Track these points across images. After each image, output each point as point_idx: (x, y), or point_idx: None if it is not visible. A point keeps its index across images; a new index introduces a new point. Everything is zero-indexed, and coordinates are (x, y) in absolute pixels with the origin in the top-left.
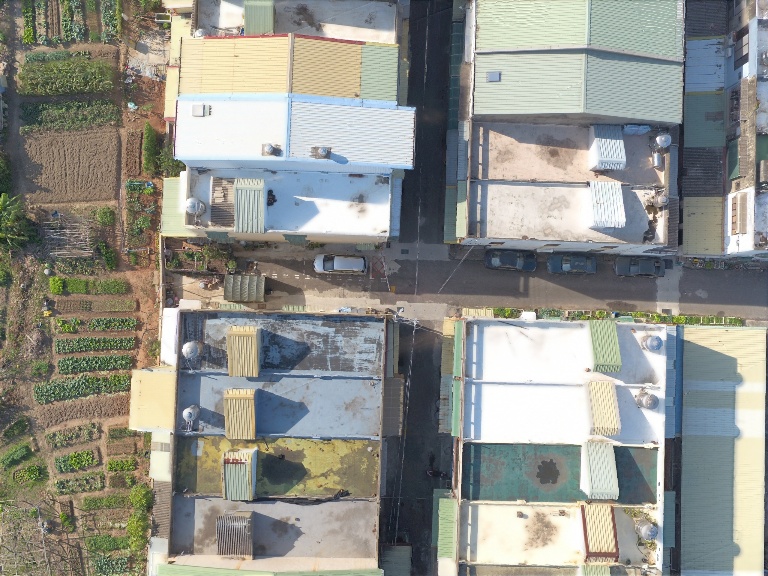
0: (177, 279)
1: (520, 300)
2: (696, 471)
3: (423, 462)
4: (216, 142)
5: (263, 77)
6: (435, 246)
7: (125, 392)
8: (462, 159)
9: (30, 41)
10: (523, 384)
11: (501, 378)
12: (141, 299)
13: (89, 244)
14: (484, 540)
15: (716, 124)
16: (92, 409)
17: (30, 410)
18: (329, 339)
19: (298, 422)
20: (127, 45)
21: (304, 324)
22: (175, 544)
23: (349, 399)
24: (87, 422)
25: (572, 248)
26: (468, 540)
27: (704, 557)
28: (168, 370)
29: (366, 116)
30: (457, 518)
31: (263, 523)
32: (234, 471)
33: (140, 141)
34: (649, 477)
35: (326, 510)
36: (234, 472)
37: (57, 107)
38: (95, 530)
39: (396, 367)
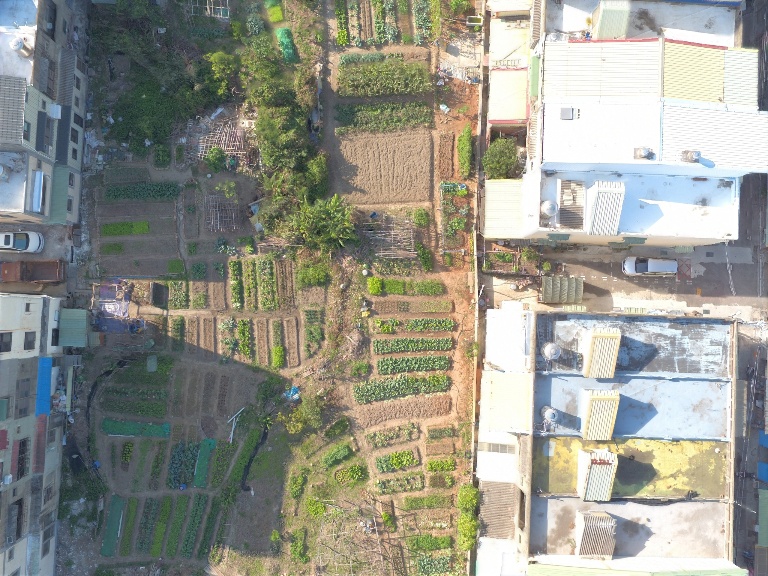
0: (488, 280)
1: None
2: None
3: None
4: (589, 145)
5: (630, 81)
6: (739, 249)
7: (443, 392)
8: None
9: (344, 43)
10: None
11: None
12: (456, 300)
13: None
14: None
15: None
16: (411, 409)
17: (349, 410)
18: (676, 341)
19: (647, 423)
20: (440, 47)
21: (652, 326)
22: None
23: (696, 401)
24: (406, 422)
25: None
26: None
27: None
28: (520, 371)
29: (730, 120)
30: None
31: None
32: (599, 472)
33: (452, 143)
34: None
35: (675, 511)
36: (599, 473)
37: (372, 109)
38: (416, 530)
39: None
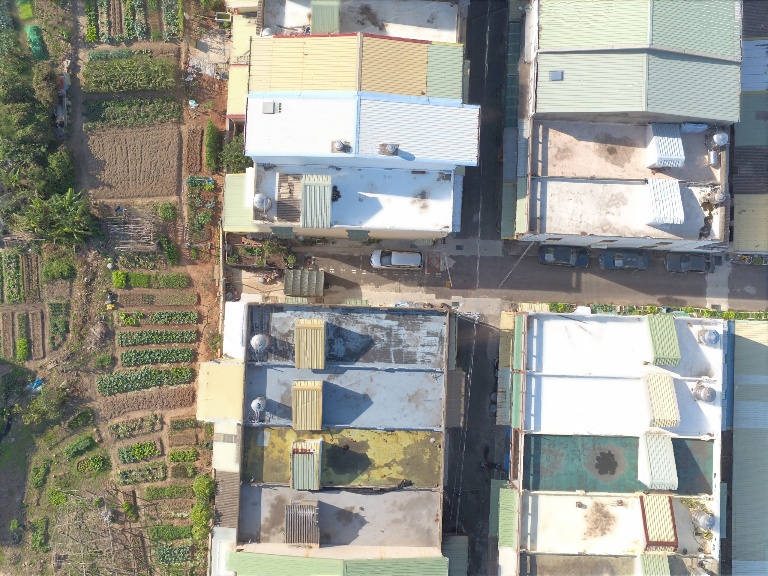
0: (236, 274)
1: (572, 295)
2: (747, 463)
3: (477, 454)
4: (287, 139)
5: (332, 75)
6: (489, 242)
7: (186, 384)
8: (522, 156)
9: (93, 39)
10: (582, 377)
11: (560, 371)
12: (202, 293)
13: (152, 239)
14: (544, 530)
15: (767, 123)
16: (154, 401)
17: (93, 402)
18: (392, 332)
19: (362, 413)
20: (188, 44)
21: (368, 317)
22: (242, 532)
23: (412, 391)
24: (149, 414)
25: (626, 244)
26: (528, 529)
27: (755, 548)
28: (235, 362)
29: (432, 114)
30: (518, 508)
31: (328, 512)
32: (302, 461)
33: (201, 138)
34: (705, 468)
35: (389, 500)
36: (302, 462)
37: (119, 104)
38: (157, 519)
39: None
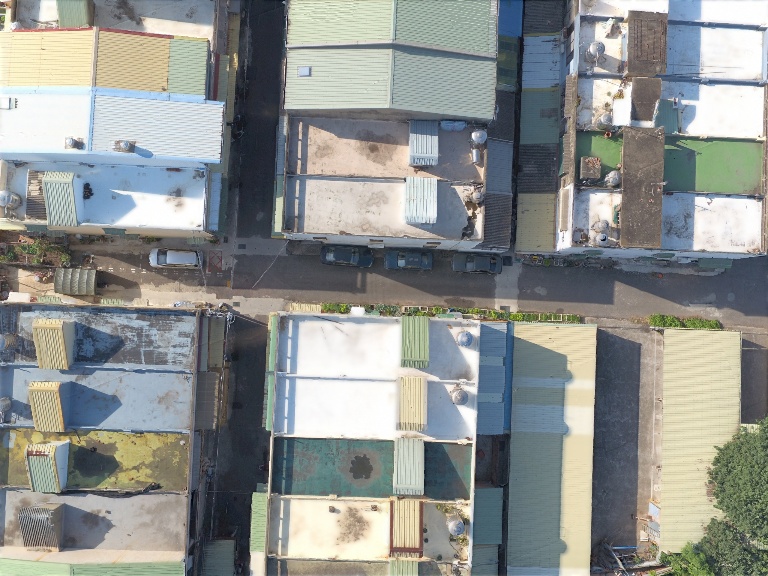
0: (13, 272)
1: (357, 296)
2: (524, 468)
3: (257, 457)
4: (19, 135)
5: (69, 70)
6: (272, 241)
7: None
8: (281, 154)
9: None
10: (337, 379)
11: (315, 373)
12: None
13: None
14: (295, 534)
15: (550, 121)
16: None
17: None
18: (143, 333)
19: (111, 415)
20: None
21: (118, 317)
22: None
23: (162, 393)
24: None
25: (402, 244)
26: (279, 534)
27: (530, 554)
28: None
29: (173, 110)
30: (267, 512)
31: (74, 515)
32: (38, 463)
33: None
34: (463, 473)
35: (137, 503)
36: (38, 464)
37: None
38: None
39: (220, 361)
